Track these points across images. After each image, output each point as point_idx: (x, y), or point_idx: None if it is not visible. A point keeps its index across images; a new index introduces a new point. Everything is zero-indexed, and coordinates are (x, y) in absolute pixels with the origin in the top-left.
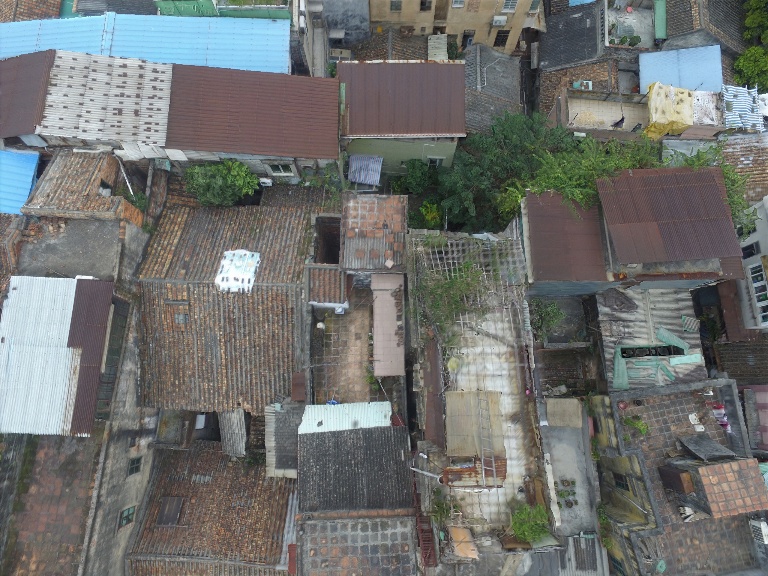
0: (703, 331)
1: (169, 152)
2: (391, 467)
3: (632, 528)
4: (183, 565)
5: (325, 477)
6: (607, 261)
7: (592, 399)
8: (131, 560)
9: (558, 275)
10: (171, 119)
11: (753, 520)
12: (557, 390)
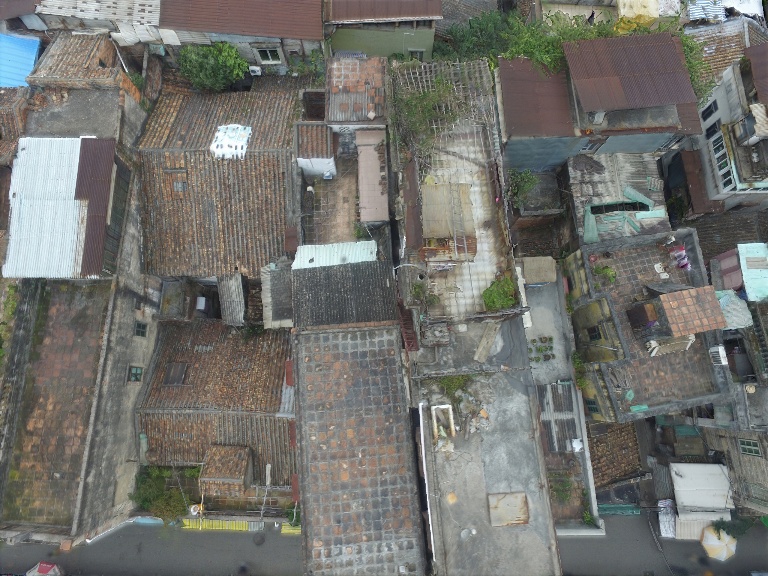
0: (673, 216)
1: (163, 34)
2: (377, 292)
3: None
4: (189, 417)
5: (317, 303)
6: (575, 120)
7: (566, 261)
8: (140, 414)
9: (529, 131)
10: (163, 2)
11: (712, 347)
12: None
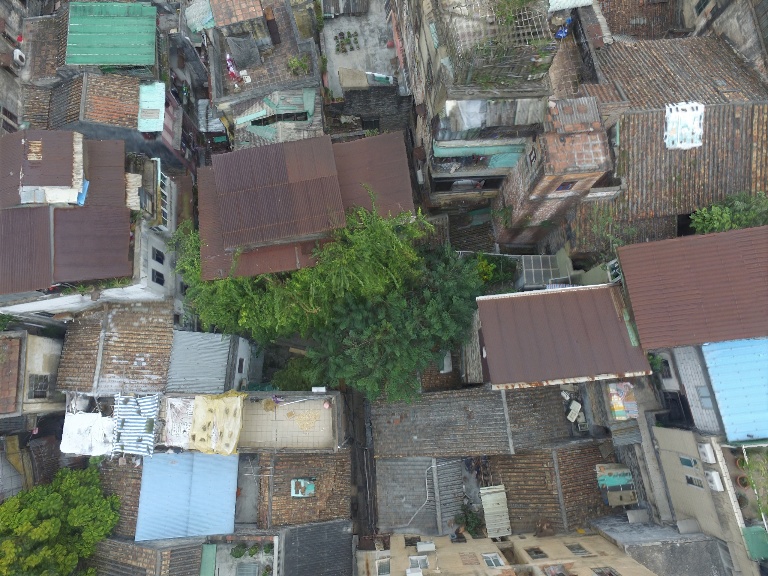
0: None
1: None
2: None
3: (305, 1)
4: None
5: None
6: None
7: None
8: None
9: (379, 139)
10: None
11: None
12: (348, 120)
